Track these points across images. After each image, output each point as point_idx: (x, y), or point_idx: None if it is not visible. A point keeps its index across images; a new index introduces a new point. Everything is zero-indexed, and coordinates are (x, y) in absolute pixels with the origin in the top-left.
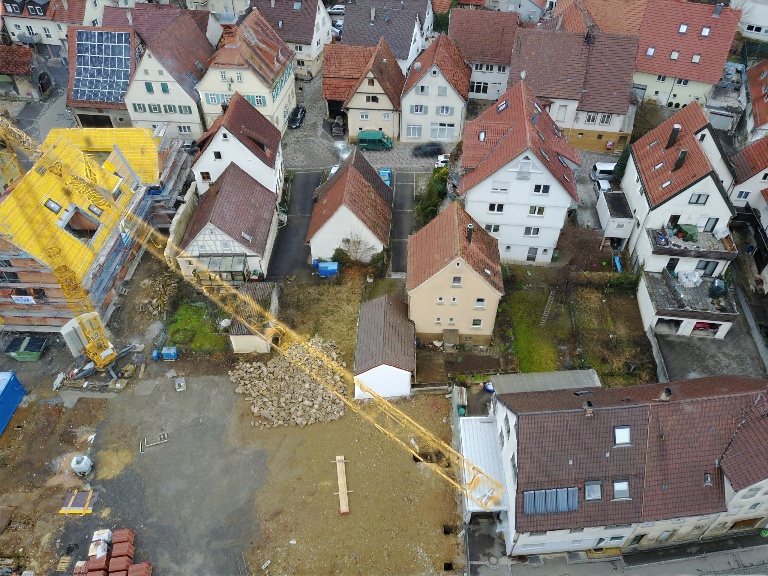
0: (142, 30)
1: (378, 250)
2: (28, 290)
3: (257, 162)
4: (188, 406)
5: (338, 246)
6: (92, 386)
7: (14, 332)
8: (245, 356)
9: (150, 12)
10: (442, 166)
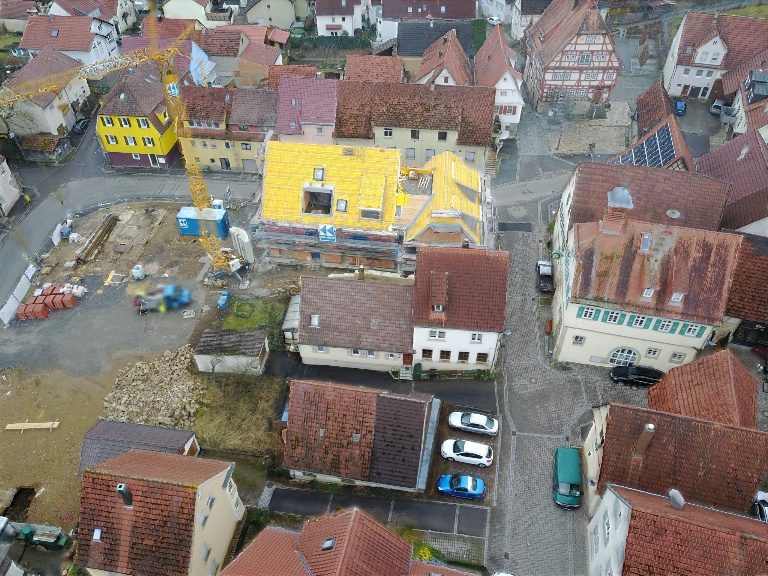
0: (733, 172)
1: None
2: None
3: None
4: (167, 322)
5: None
6: None
7: None
8: None
9: (762, 163)
10: None
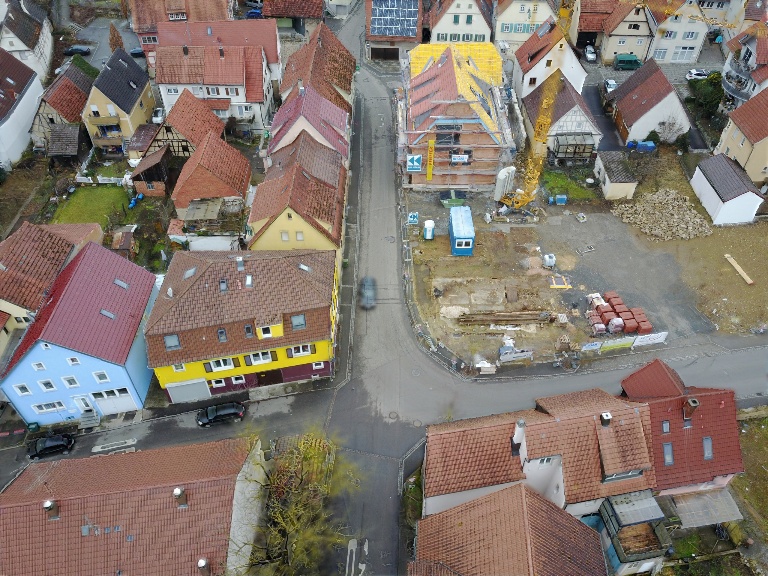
0: None
1: (684, 131)
2: (460, 152)
3: (578, 68)
4: (595, 230)
5: (653, 129)
6: (514, 221)
7: (428, 191)
8: (616, 201)
9: None
10: (695, 78)
